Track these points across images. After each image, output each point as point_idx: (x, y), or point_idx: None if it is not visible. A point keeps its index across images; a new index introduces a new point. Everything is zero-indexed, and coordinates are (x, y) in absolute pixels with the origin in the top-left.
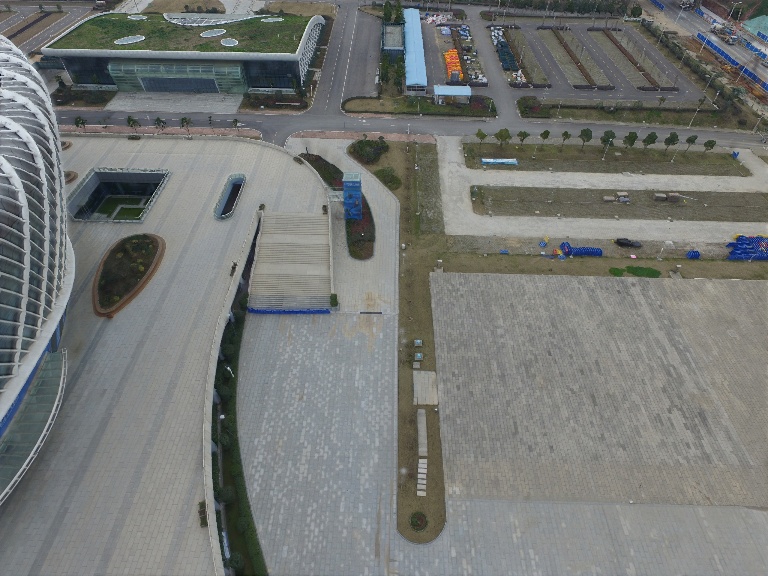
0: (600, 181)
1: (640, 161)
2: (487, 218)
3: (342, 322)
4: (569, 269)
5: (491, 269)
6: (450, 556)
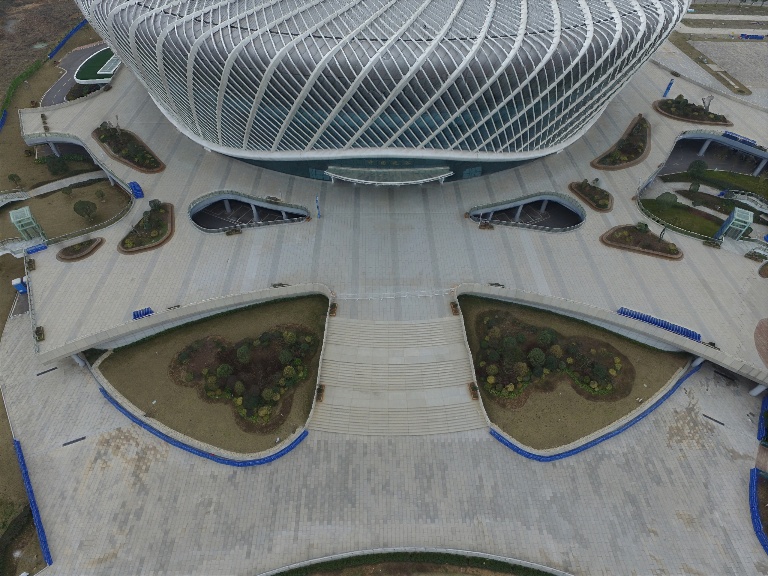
0: (744, 18)
1: (760, 11)
2: (696, 28)
3: (660, 54)
4: (752, 40)
5: (715, 40)
6: (759, 97)
